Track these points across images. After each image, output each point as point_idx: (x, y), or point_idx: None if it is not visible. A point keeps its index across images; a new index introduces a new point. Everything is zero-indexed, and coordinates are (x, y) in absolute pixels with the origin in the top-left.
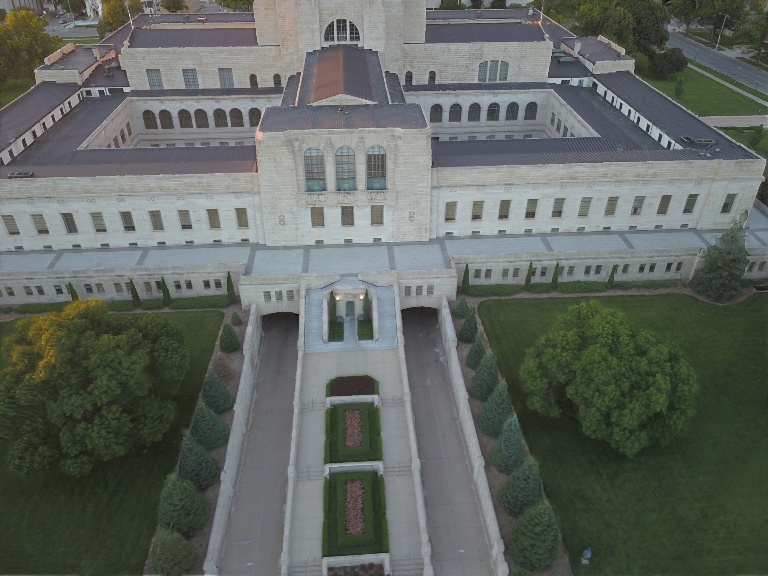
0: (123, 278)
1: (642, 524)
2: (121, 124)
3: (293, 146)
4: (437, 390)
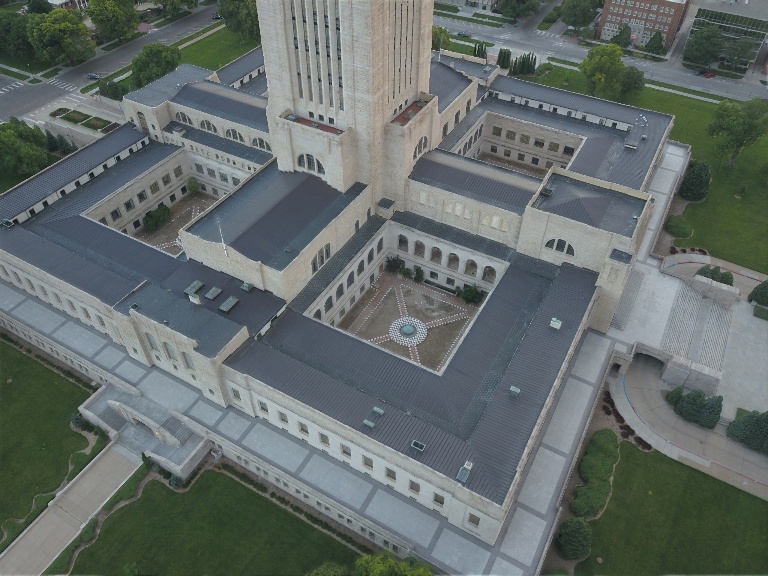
0: None
1: None
2: None
3: None
4: None
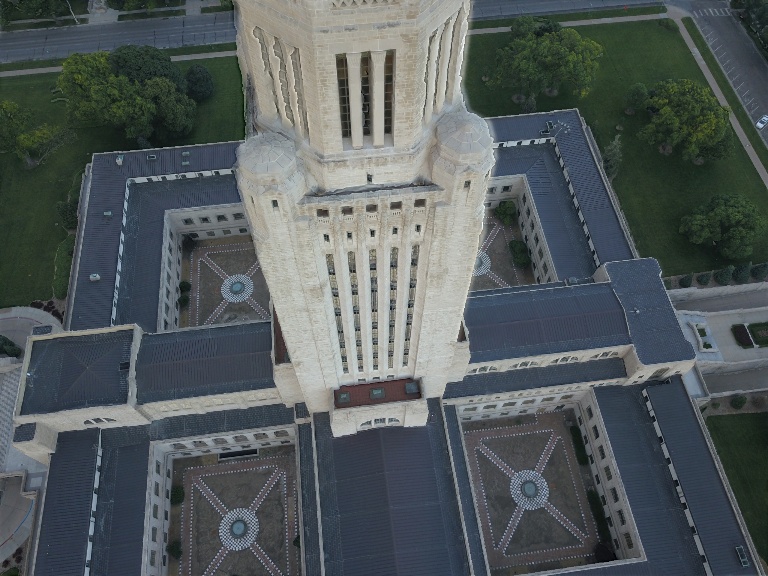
0: None
1: (766, 235)
2: None
3: None
4: (703, 306)
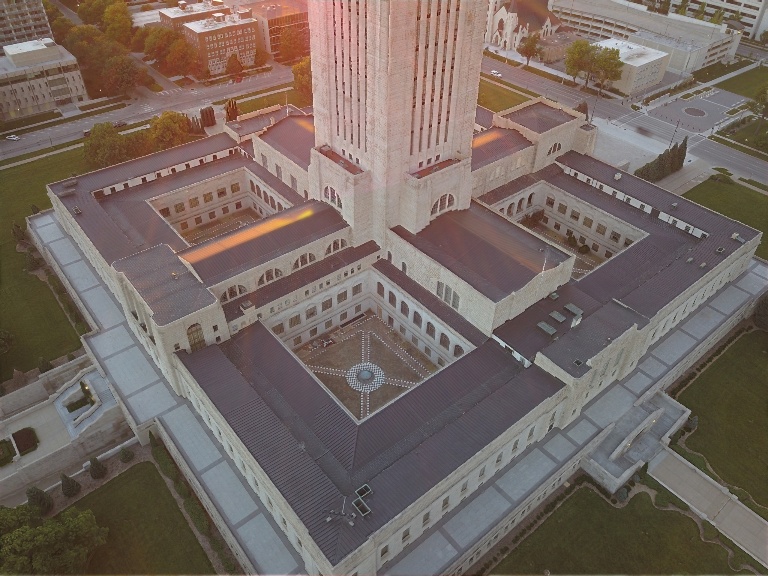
0: (72, 294)
1: None
2: (223, 185)
3: (123, 283)
4: None
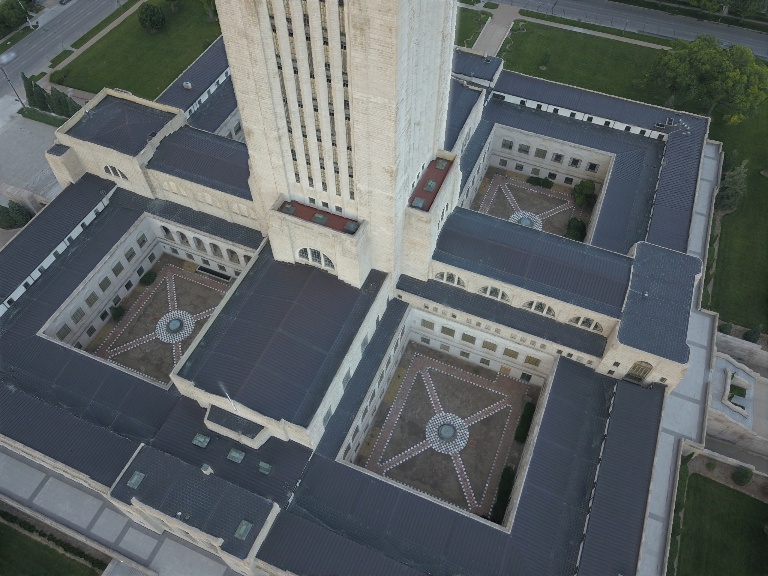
0: None
1: None
2: None
3: None
4: (764, 376)
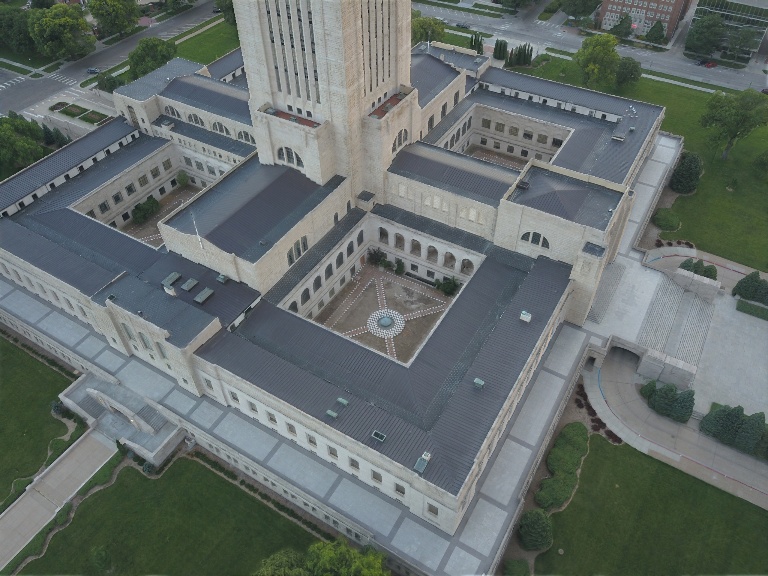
0: None
1: None
2: None
3: None
4: None
